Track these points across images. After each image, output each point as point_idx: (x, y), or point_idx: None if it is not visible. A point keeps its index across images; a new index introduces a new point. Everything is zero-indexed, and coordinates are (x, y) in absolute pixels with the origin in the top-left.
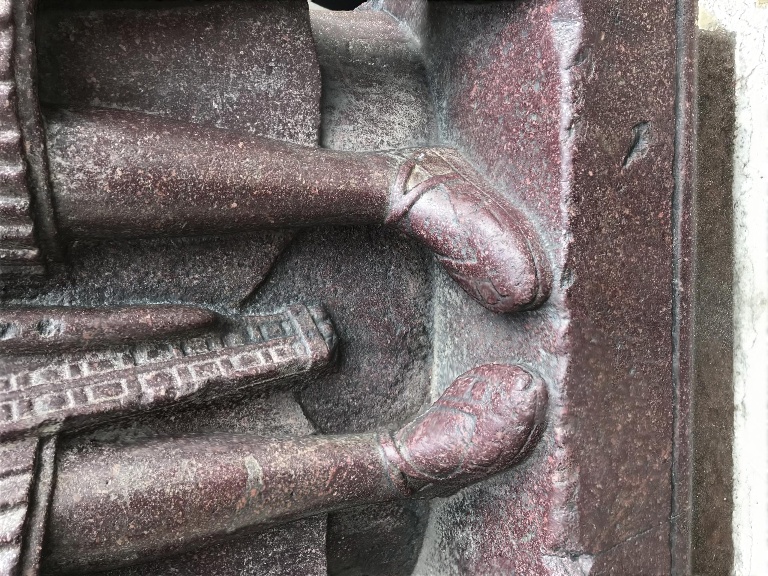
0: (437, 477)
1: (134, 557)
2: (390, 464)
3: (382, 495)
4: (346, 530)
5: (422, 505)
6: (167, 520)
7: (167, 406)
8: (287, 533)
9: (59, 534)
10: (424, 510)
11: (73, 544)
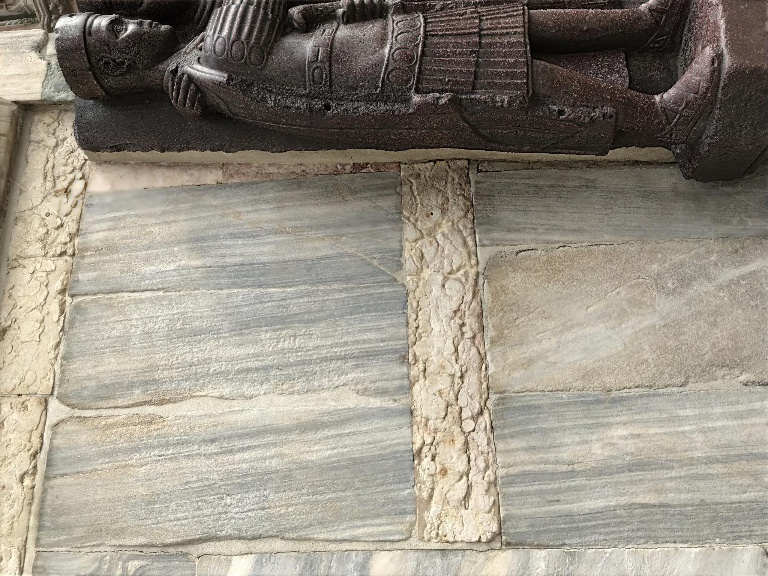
0: (665, 8)
1: (554, 32)
2: (644, 8)
3: (644, 24)
4: (637, 76)
5: (672, 65)
6: (563, 18)
7: (558, 5)
8: (608, 59)
9: (532, 17)
10: (674, 67)
11: (536, 21)
